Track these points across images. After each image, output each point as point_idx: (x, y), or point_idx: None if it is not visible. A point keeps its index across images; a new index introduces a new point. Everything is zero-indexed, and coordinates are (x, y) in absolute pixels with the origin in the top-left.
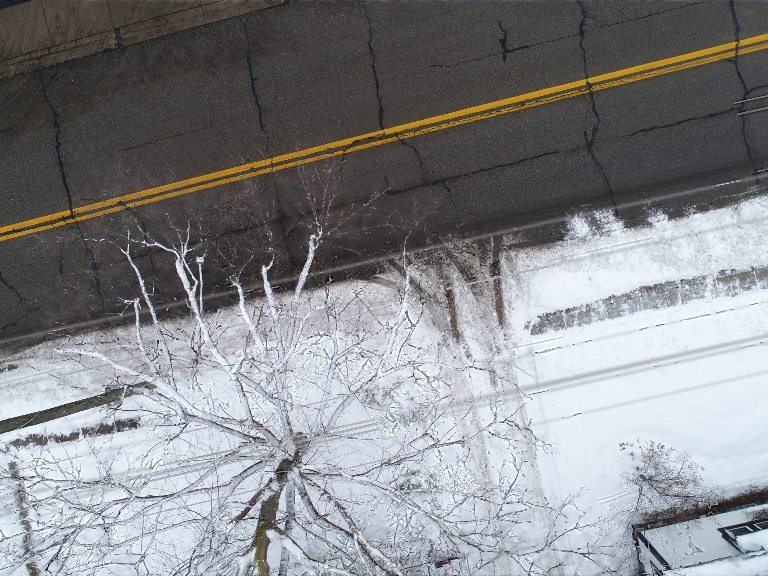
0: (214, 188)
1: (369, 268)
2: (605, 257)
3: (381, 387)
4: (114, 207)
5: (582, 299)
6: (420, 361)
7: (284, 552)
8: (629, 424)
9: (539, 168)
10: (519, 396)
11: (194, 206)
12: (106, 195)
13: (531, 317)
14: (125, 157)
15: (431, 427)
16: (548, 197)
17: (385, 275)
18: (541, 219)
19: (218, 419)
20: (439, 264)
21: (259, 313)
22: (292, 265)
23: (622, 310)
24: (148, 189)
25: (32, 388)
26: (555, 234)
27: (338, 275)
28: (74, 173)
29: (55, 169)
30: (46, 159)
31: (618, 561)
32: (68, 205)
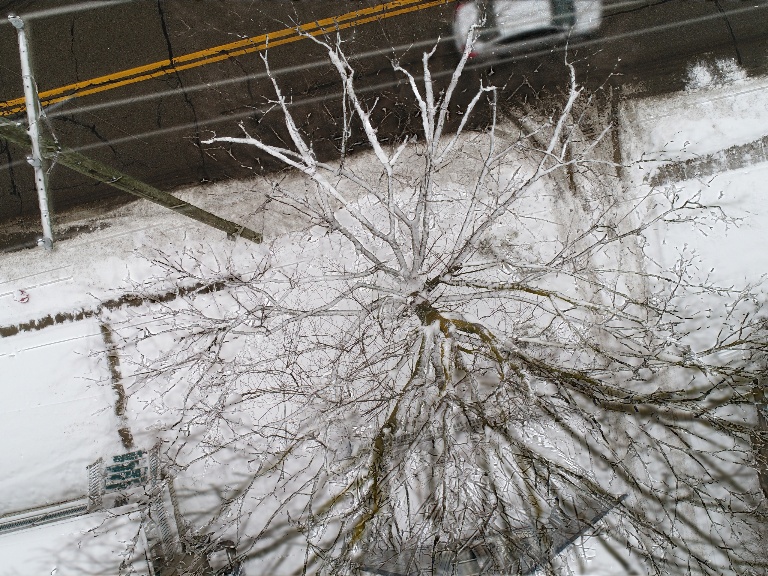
0: (322, 36)
1: (483, 119)
2: (729, 105)
3: (498, 238)
4: (216, 56)
5: (704, 148)
6: (535, 214)
7: (437, 360)
8: (753, 275)
9: (661, 15)
10: (638, 249)
11: (301, 55)
12: (208, 44)
13: (650, 168)
14: (229, 4)
15: (600, 220)
16: (669, 45)
17: (499, 126)
18: (662, 68)
19: (368, 223)
20: (555, 115)
21: (368, 165)
22: (403, 116)
23: (744, 161)
24: (253, 37)
25: (128, 245)
26: (676, 83)
27: (450, 126)
28: (174, 21)
29: (154, 17)
30: (145, 6)
31: (738, 418)
32: (168, 54)
